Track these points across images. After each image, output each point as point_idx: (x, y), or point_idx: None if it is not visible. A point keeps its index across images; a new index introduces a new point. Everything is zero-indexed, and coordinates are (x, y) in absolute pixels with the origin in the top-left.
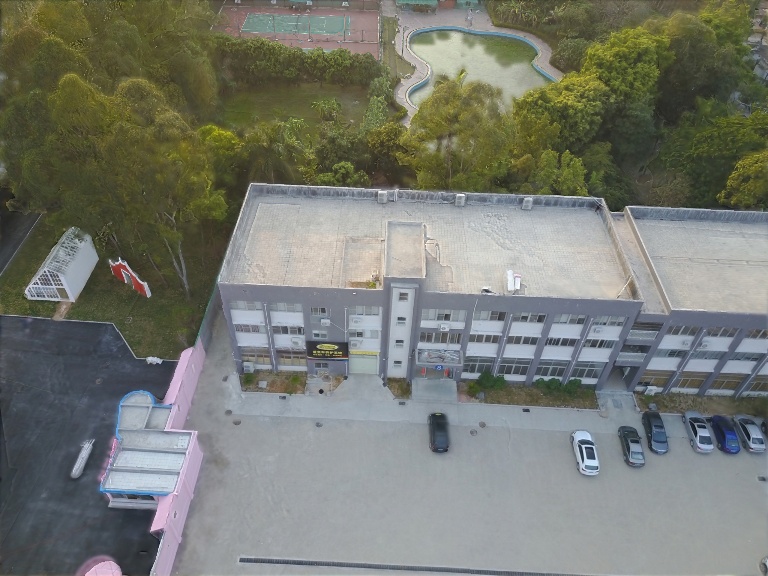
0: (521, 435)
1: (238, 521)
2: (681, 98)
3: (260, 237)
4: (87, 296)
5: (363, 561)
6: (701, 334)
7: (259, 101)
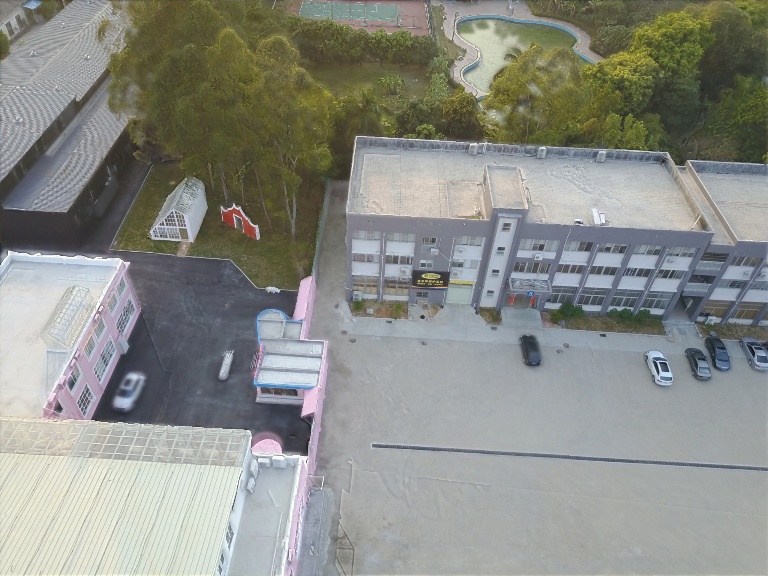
0: (601, 354)
1: (366, 416)
2: (719, 77)
3: (371, 180)
4: (203, 238)
5: (478, 448)
6: (761, 265)
7: (326, 78)
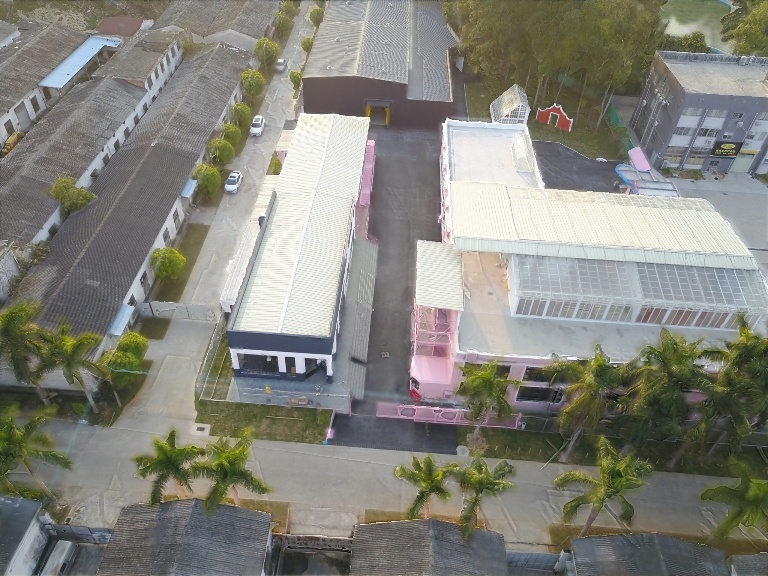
0: None
1: None
2: None
3: (681, 78)
4: (529, 129)
5: None
6: None
7: None
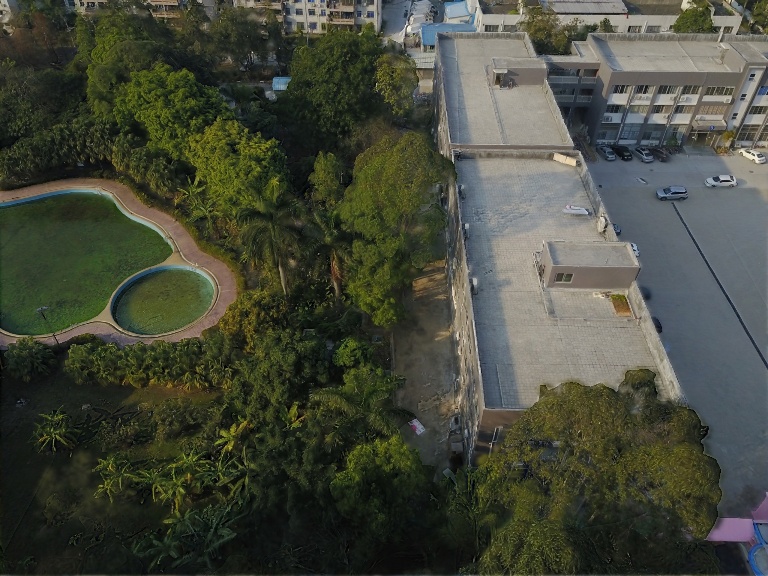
0: None
1: None
2: None
3: None
4: None
5: None
6: None
7: None
